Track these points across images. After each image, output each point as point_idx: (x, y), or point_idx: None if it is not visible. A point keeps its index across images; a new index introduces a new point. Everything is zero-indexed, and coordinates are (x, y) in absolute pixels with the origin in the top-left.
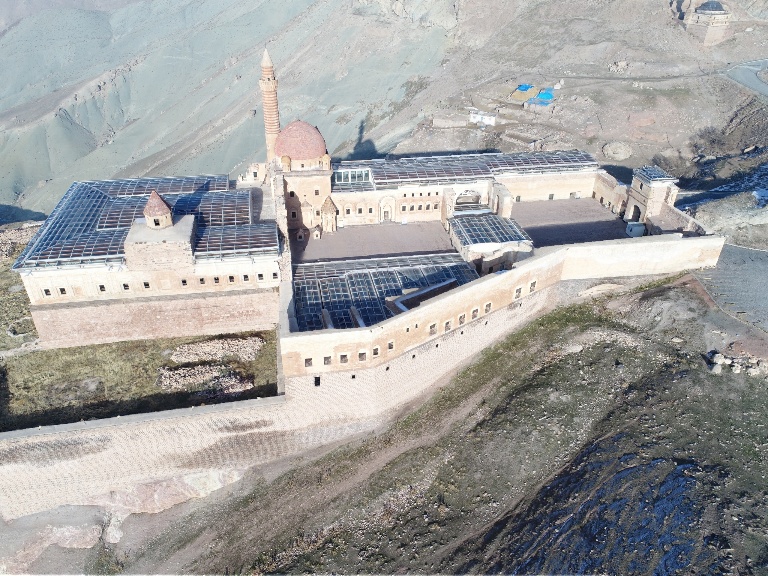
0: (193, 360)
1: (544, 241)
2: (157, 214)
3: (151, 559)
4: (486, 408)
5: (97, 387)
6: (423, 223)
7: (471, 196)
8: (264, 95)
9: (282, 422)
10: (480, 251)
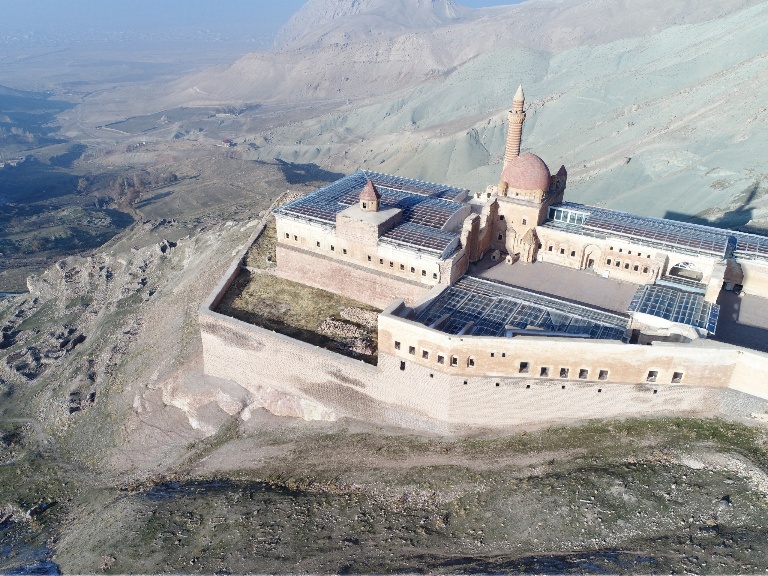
0: (353, 320)
1: (757, 346)
2: (366, 199)
3: (254, 442)
4: (549, 468)
5: (285, 311)
6: (626, 283)
7: (694, 271)
8: (510, 126)
9: (373, 389)
10: (645, 322)
